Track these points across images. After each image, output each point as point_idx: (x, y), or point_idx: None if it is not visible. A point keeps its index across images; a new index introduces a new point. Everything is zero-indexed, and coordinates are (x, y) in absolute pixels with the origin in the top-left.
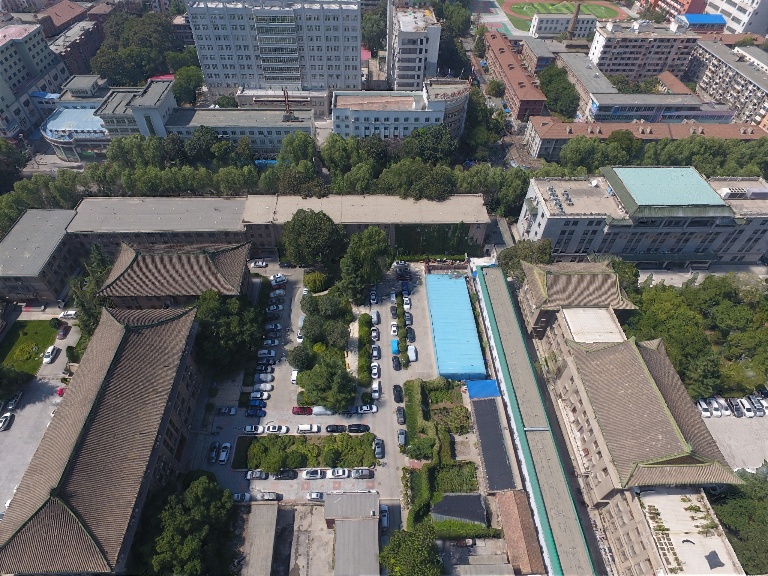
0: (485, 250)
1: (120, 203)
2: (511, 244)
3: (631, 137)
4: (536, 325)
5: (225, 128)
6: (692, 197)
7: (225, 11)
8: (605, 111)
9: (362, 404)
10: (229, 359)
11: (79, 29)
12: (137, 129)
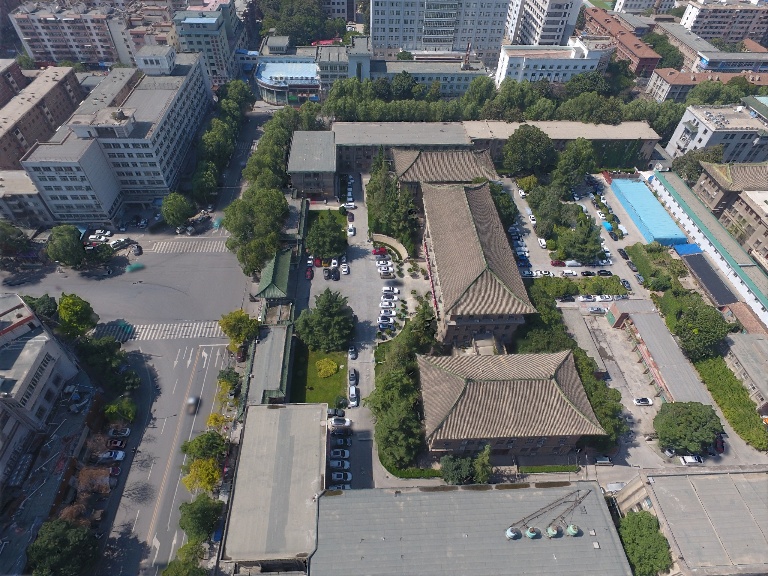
0: (649, 165)
1: (363, 126)
2: (670, 159)
3: (747, 82)
4: (716, 208)
5: (418, 74)
6: None
7: None
8: (713, 66)
9: (600, 260)
10: (503, 225)
11: (242, 2)
12: (344, 75)
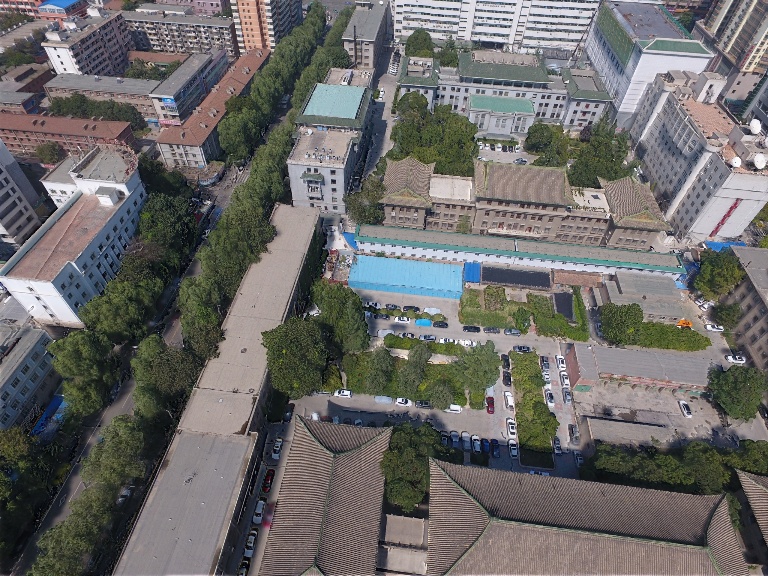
0: None
1: None
2: (326, 214)
3: None
4: None
5: None
6: None
7: None
8: (178, 99)
9: None
10: None
11: None
12: None
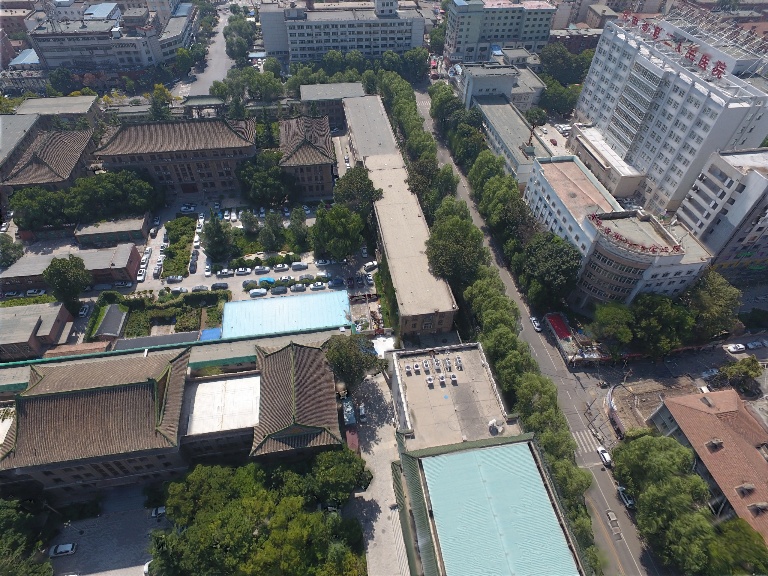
0: None
1: (377, 108)
2: None
3: (756, 567)
4: None
5: (489, 122)
6: (470, 574)
7: (623, 45)
8: None
9: None
10: (240, 185)
11: None
12: None
